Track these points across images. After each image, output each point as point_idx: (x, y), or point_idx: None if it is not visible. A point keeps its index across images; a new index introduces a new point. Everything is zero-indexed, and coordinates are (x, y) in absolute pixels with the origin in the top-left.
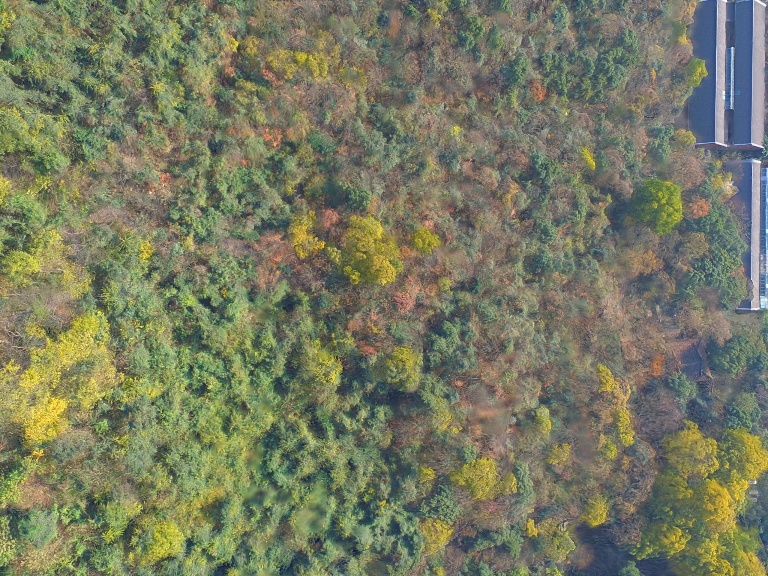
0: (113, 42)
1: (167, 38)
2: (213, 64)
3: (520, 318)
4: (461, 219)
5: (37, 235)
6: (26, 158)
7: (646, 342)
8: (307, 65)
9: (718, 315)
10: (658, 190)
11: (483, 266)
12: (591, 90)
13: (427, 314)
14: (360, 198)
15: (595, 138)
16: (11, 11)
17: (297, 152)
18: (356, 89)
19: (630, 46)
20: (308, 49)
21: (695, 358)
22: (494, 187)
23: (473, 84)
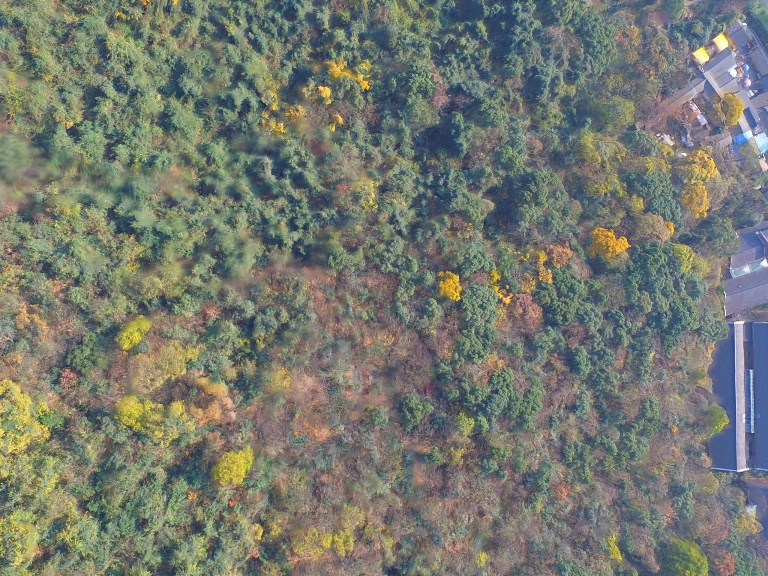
0: None
1: (192, 561)
2: (238, 568)
3: None
4: None
5: None
6: None
7: None
8: (333, 549)
9: None
10: (685, 567)
11: None
12: (614, 464)
13: None
14: None
15: (619, 512)
16: None
17: None
18: (381, 541)
19: (652, 418)
20: (333, 528)
21: None
22: None
23: (497, 496)
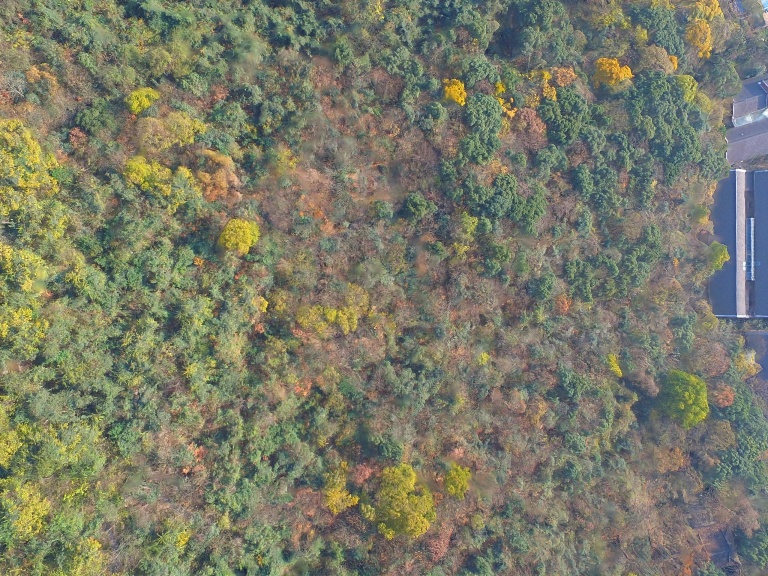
0: (145, 332)
1: (198, 317)
2: (244, 333)
3: (550, 532)
4: (490, 442)
5: (75, 546)
6: (63, 471)
7: (673, 527)
8: (337, 323)
9: (745, 504)
10: (684, 389)
11: (513, 486)
12: (615, 289)
13: (460, 549)
14: (393, 454)
15: (620, 336)
16: (44, 320)
17: (327, 401)
18: (384, 330)
19: (653, 243)
20: (337, 304)
21: (723, 546)
22: (523, 411)
23: (499, 303)
